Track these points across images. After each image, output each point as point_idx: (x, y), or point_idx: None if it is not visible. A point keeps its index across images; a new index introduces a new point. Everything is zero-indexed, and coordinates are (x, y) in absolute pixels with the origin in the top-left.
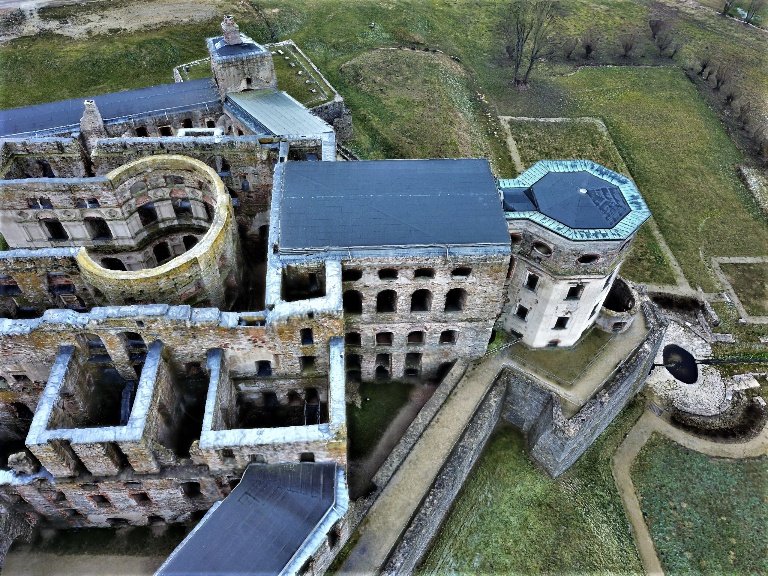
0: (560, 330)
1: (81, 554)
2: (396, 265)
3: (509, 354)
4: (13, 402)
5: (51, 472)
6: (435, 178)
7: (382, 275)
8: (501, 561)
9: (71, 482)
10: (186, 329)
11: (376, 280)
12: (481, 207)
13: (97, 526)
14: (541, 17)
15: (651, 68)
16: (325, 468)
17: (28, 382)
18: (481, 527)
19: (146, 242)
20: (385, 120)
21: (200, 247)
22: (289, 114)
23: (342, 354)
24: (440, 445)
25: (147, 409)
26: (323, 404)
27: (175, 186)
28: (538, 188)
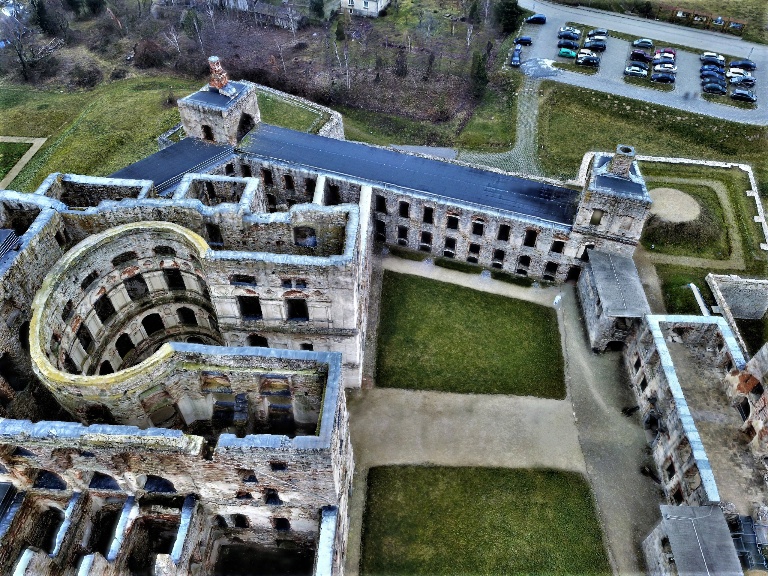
0: None
1: None
2: None
3: None
4: None
5: None
6: None
7: None
8: None
9: None
10: None
11: None
12: None
13: None
14: None
15: None
16: None
17: None
18: None
19: None
20: None
21: (88, 243)
22: None
23: None
24: None
25: None
26: None
27: None
28: None
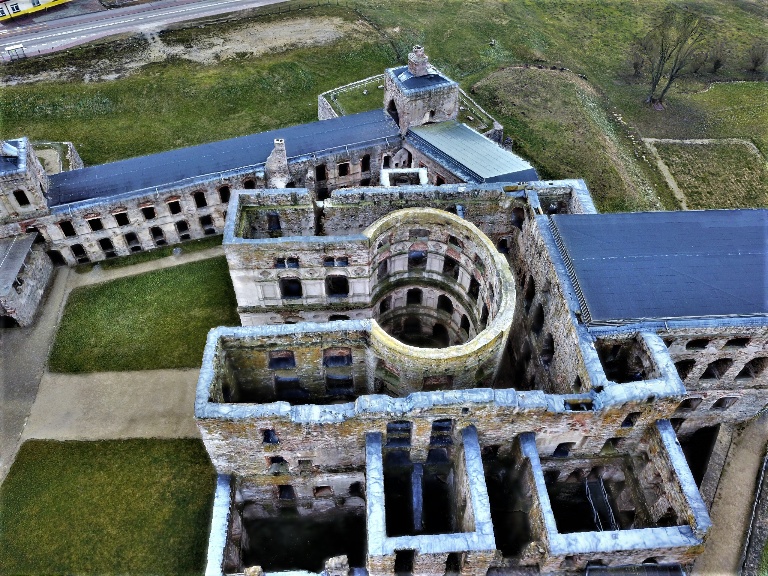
0: None
1: None
2: (711, 335)
3: None
4: (283, 484)
5: None
6: (724, 233)
7: (688, 345)
8: None
9: None
10: (510, 415)
11: (681, 350)
12: None
13: None
14: (685, 34)
15: None
16: (671, 571)
17: (306, 465)
18: None
19: (377, 298)
20: (537, 146)
21: (502, 319)
22: (481, 150)
23: None
24: (732, 526)
25: (489, 510)
26: (605, 482)
27: (417, 239)
28: None
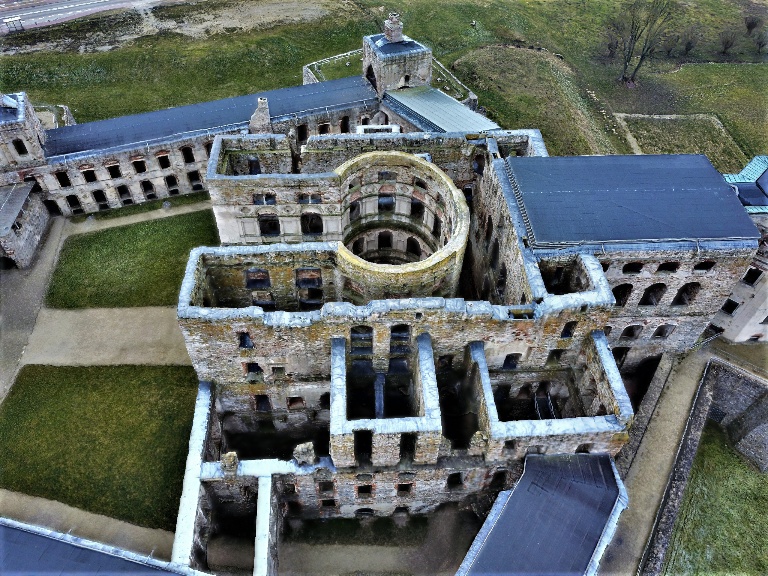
0: (767, 324)
1: (332, 544)
2: (644, 259)
3: (710, 348)
4: (259, 394)
5: (335, 462)
6: (662, 173)
7: (625, 269)
8: (732, 553)
9: (352, 472)
10: (460, 322)
11: (619, 274)
12: (719, 202)
13: (342, 516)
14: (655, 14)
15: (753, 65)
16: (601, 459)
17: (280, 374)
18: (704, 520)
19: (350, 237)
20: (511, 117)
21: (456, 241)
22: (452, 111)
23: (608, 347)
24: (667, 438)
25: None
26: (552, 397)
27: (386, 182)
28: (765, 183)
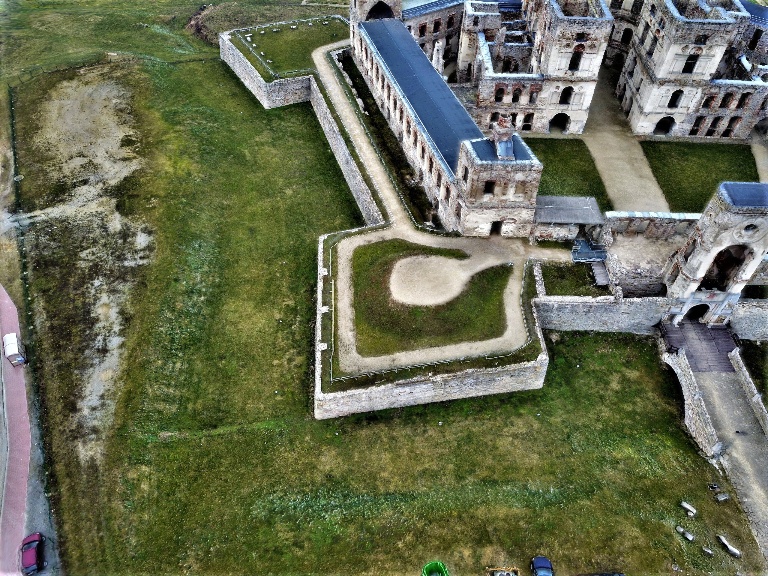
0: None
1: None
2: None
3: None
4: None
5: None
6: None
7: None
8: None
9: None
10: None
11: None
12: None
13: None
14: None
15: None
16: None
17: None
18: None
19: None
20: None
21: None
22: None
23: None
24: None
25: None
26: None
27: None
28: None
